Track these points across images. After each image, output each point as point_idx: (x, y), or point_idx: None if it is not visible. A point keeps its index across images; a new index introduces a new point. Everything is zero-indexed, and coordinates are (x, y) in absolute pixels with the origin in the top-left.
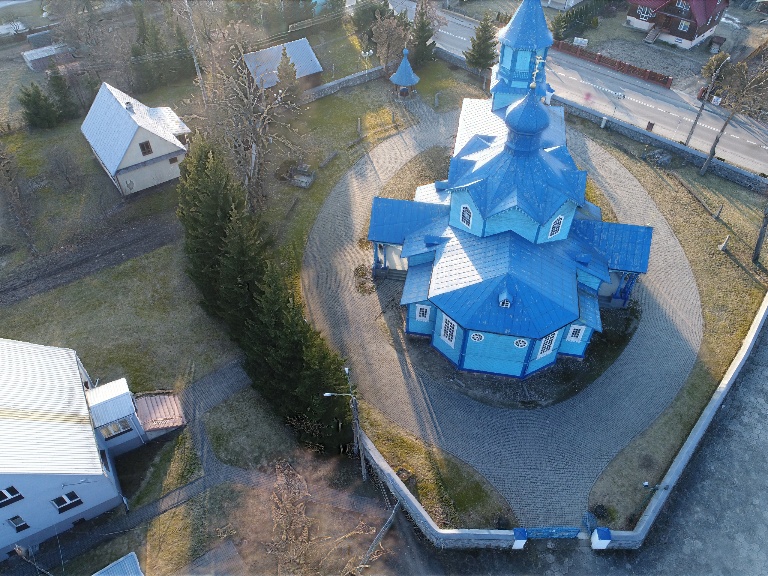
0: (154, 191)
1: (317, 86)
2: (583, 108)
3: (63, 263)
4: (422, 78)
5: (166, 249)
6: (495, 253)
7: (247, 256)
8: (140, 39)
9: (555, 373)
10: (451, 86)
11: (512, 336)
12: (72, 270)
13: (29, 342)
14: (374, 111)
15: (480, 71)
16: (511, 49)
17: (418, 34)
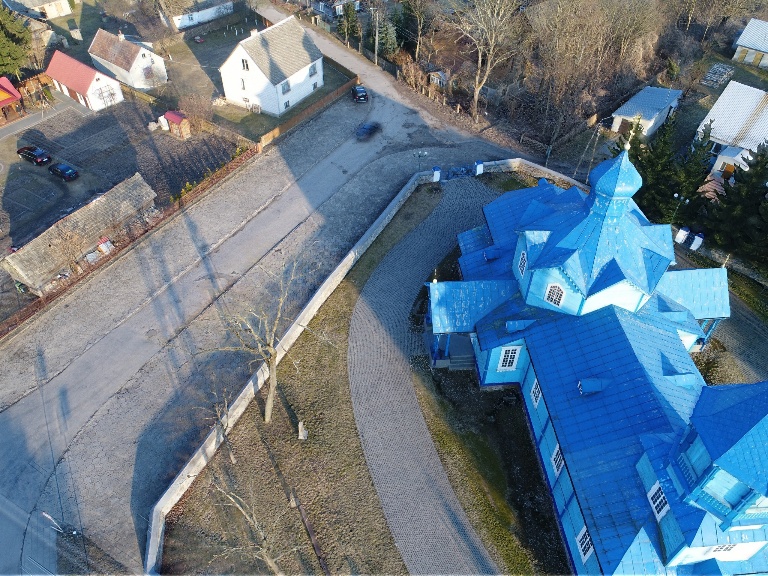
0: None
1: None
2: None
3: None
4: None
5: None
6: None
7: None
8: None
9: None
10: None
11: None
12: None
13: None
14: None
15: None
16: None
17: None
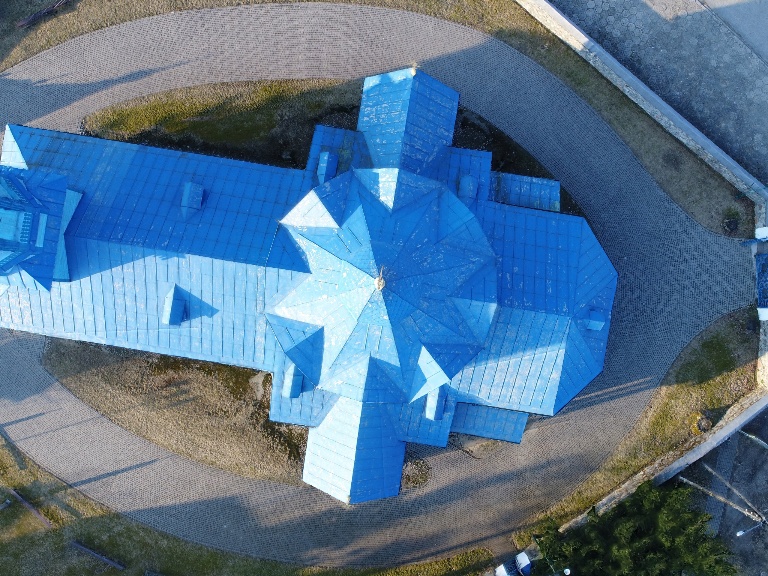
0: None
1: None
2: None
3: None
4: None
5: None
6: (516, 328)
7: None
8: None
9: None
10: None
11: None
12: None
13: None
14: None
15: None
16: None
17: None
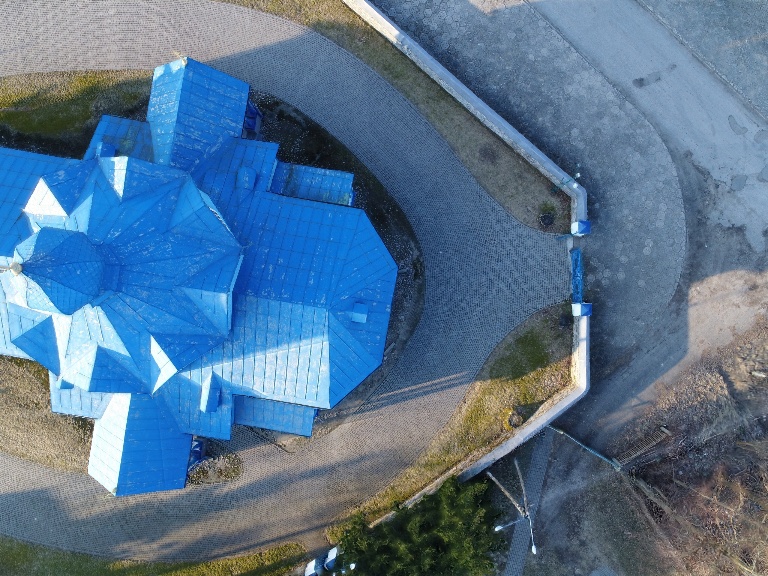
0: None
1: None
2: None
3: None
4: None
5: None
6: (276, 320)
7: None
8: None
9: None
10: None
11: None
12: None
13: None
14: None
15: None
16: None
17: None
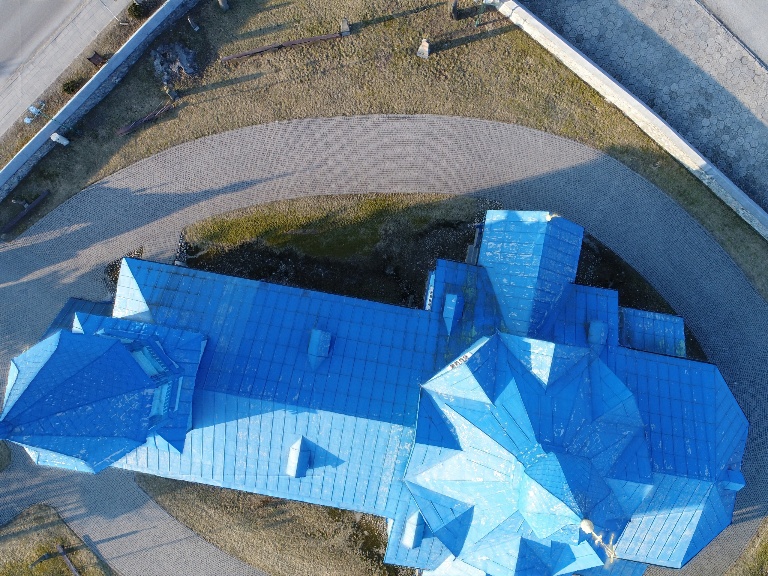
0: None
1: None
2: (10, 170)
3: None
4: None
5: None
6: (654, 490)
7: None
8: None
9: None
10: None
11: None
12: None
13: None
14: None
15: None
16: None
17: None
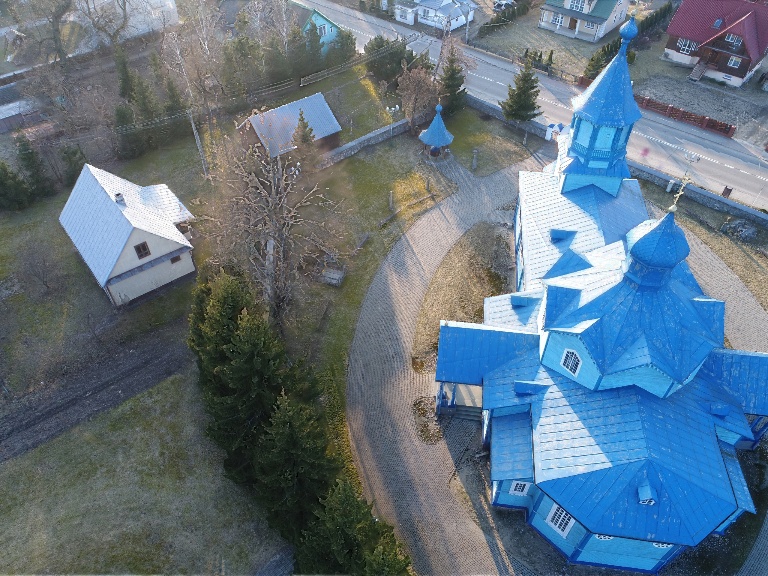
0: (153, 296)
1: (335, 148)
2: (644, 168)
3: (44, 408)
4: (452, 132)
5: (174, 381)
6: (620, 420)
7: (299, 447)
8: (125, 98)
9: (690, 558)
10: (487, 141)
11: (657, 542)
12: (56, 418)
13: (4, 535)
14: (403, 176)
15: (518, 122)
16: (591, 124)
17: (448, 83)
